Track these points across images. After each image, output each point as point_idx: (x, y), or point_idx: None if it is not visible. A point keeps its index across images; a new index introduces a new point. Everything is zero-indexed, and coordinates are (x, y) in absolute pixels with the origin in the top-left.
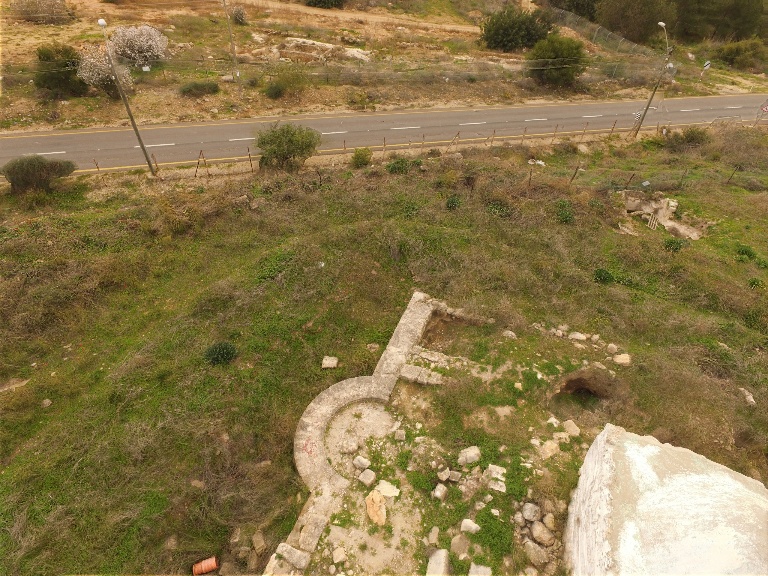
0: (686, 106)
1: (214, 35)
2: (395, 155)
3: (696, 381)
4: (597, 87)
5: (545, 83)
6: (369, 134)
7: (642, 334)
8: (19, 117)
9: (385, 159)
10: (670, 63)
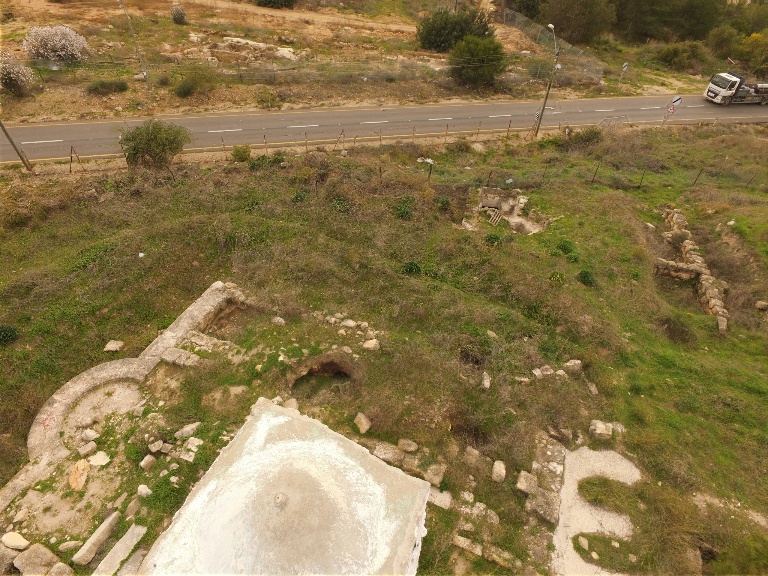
0: (602, 106)
1: (149, 35)
2: (280, 152)
3: (434, 365)
4: (520, 87)
5: (466, 83)
6: (263, 132)
7: (420, 322)
8: None
9: (269, 156)
10: (558, 64)
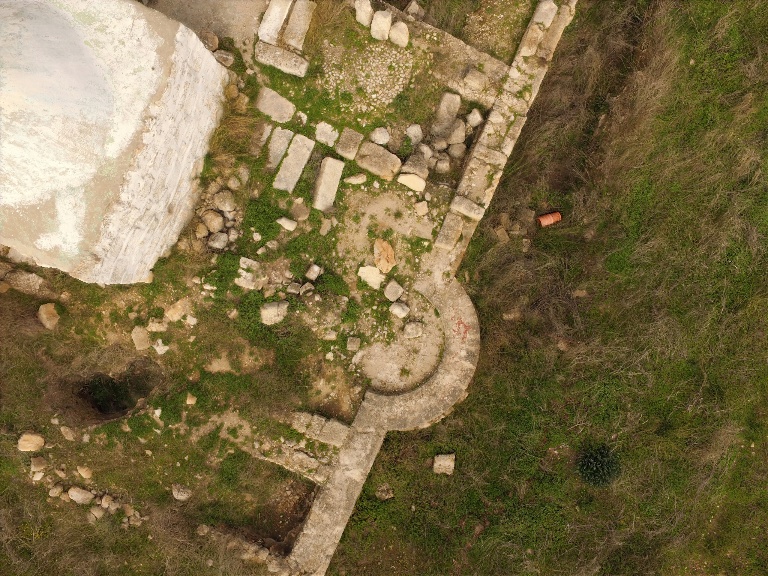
0: None
1: None
2: None
3: None
4: None
5: None
6: None
7: None
8: None
9: None
10: None
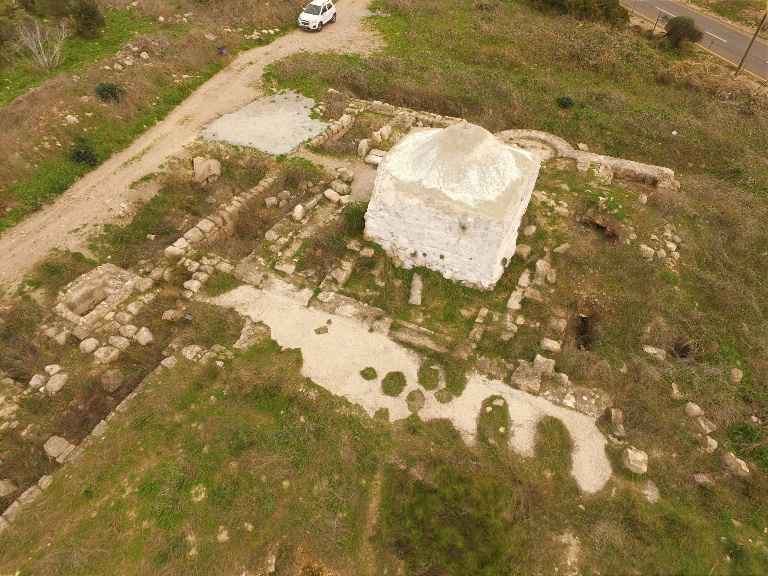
0: None
1: None
2: None
3: None
4: None
5: None
6: None
7: (713, 308)
8: (752, 19)
9: None
10: None
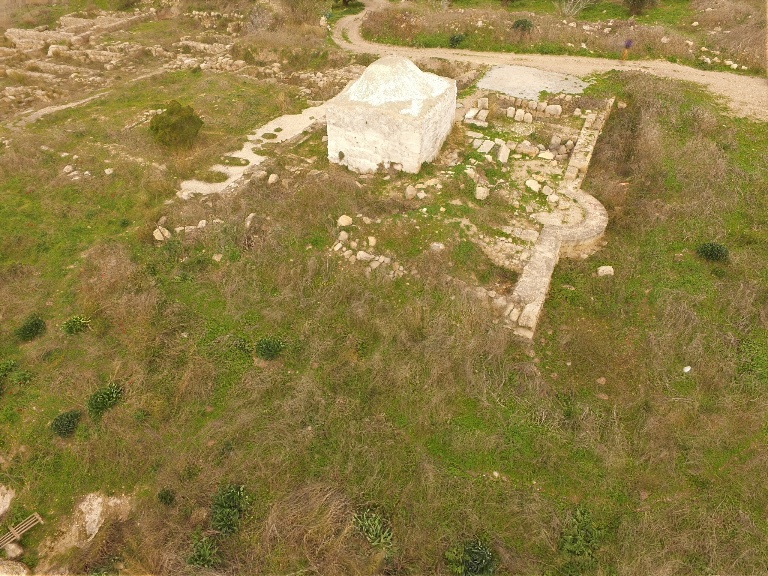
0: None
1: None
2: None
3: None
4: None
5: None
6: None
7: None
8: None
9: None
10: None
